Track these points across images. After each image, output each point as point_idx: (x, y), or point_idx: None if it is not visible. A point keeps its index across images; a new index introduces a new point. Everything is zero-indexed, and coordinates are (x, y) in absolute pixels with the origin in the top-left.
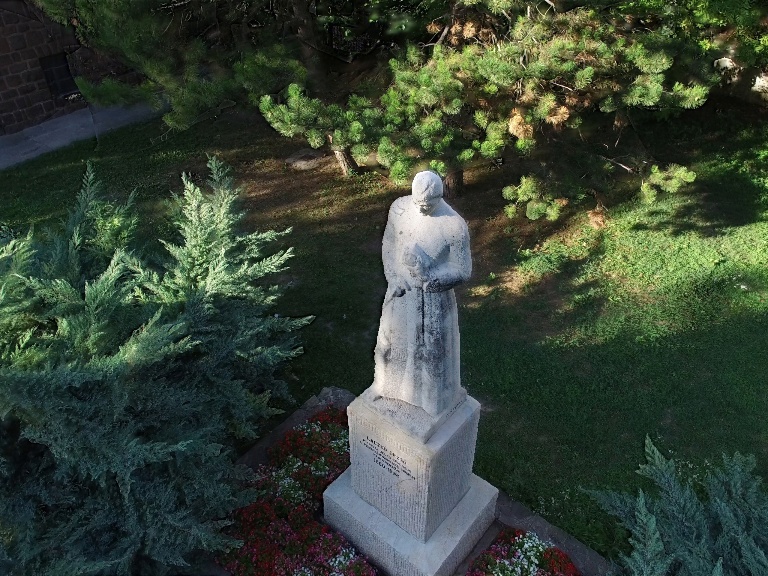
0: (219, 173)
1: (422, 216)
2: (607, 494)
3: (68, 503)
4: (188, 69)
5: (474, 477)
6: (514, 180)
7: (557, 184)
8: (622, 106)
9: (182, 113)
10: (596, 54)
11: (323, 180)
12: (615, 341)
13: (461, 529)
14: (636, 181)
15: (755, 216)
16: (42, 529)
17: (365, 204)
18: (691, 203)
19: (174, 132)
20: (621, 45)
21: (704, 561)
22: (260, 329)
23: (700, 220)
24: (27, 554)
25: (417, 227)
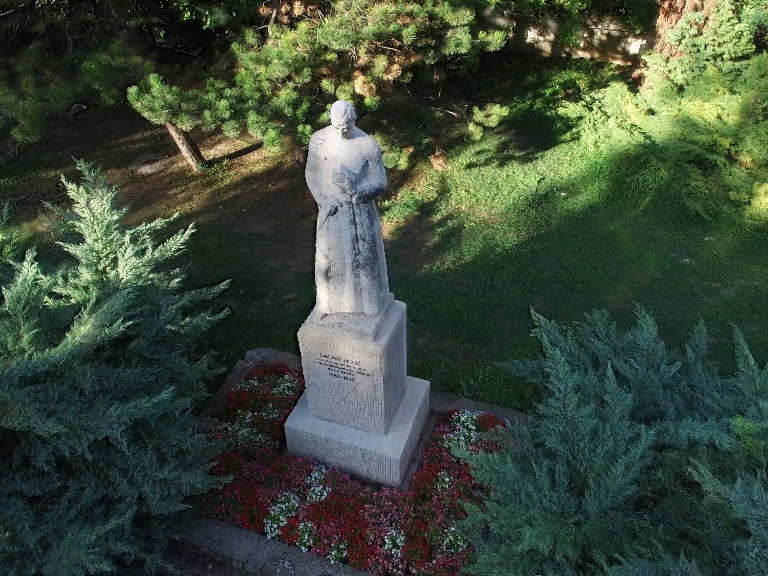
0: (91, 174)
1: (341, 141)
2: (512, 362)
3: (50, 493)
4: (25, 80)
5: (407, 378)
6: None
7: (401, 135)
8: (442, 57)
9: (30, 124)
10: (413, 15)
11: (174, 179)
12: (480, 256)
13: (410, 418)
14: (463, 123)
15: (556, 140)
16: (31, 523)
17: (225, 192)
18: (505, 139)
19: (23, 146)
20: (431, 5)
21: (595, 381)
22: (183, 302)
23: (516, 151)
24: (32, 540)
25: (339, 151)
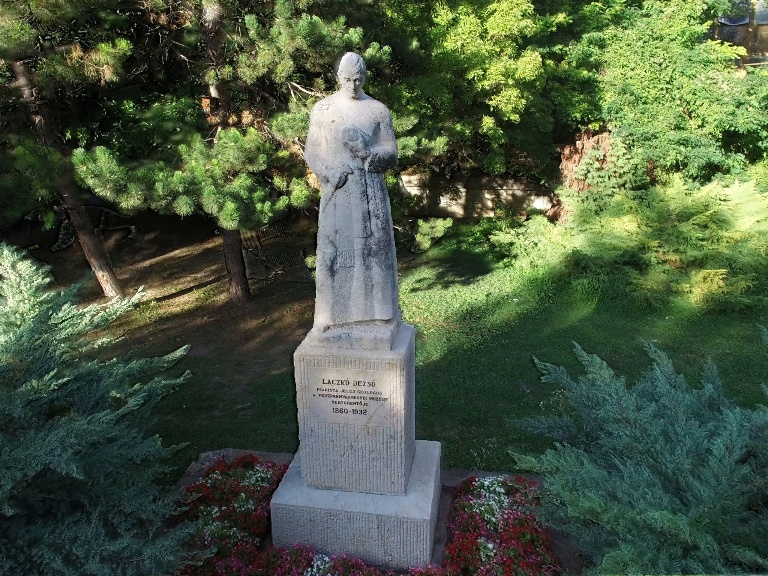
0: (14, 257)
1: (350, 102)
2: (525, 420)
3: None
4: None
5: None
6: (312, 251)
7: None
8: None
9: None
10: None
11: None
12: (449, 353)
13: (430, 477)
14: (408, 238)
15: (492, 268)
16: None
17: (154, 327)
18: (443, 270)
19: None
20: None
21: None
22: (132, 366)
23: (456, 277)
24: None
25: (349, 111)
